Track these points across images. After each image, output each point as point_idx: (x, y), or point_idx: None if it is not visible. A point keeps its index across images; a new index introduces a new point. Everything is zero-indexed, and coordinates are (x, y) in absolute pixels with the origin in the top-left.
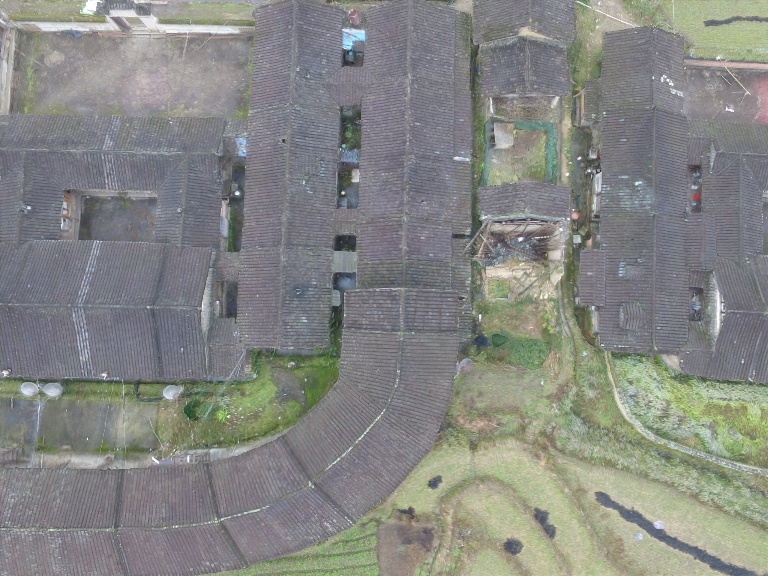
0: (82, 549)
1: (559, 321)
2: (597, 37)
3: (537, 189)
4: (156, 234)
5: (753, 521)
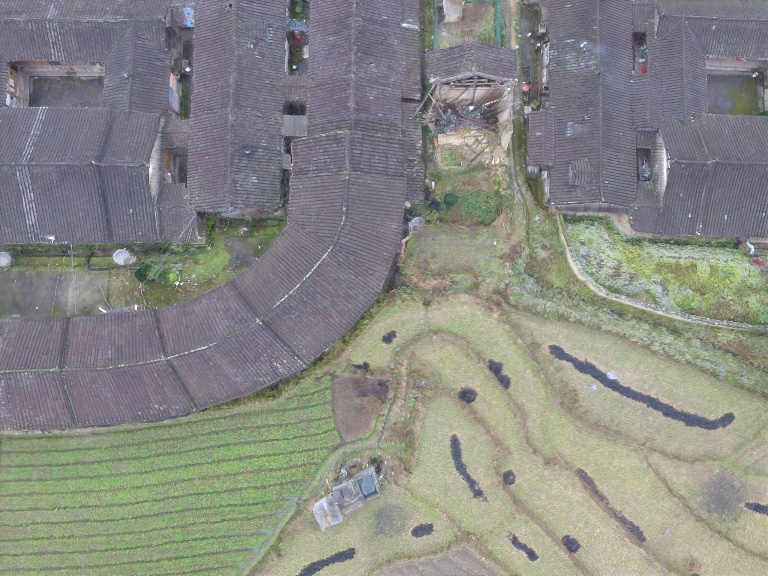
0: (26, 392)
1: (511, 186)
2: None
3: (484, 49)
4: (104, 103)
5: (703, 368)
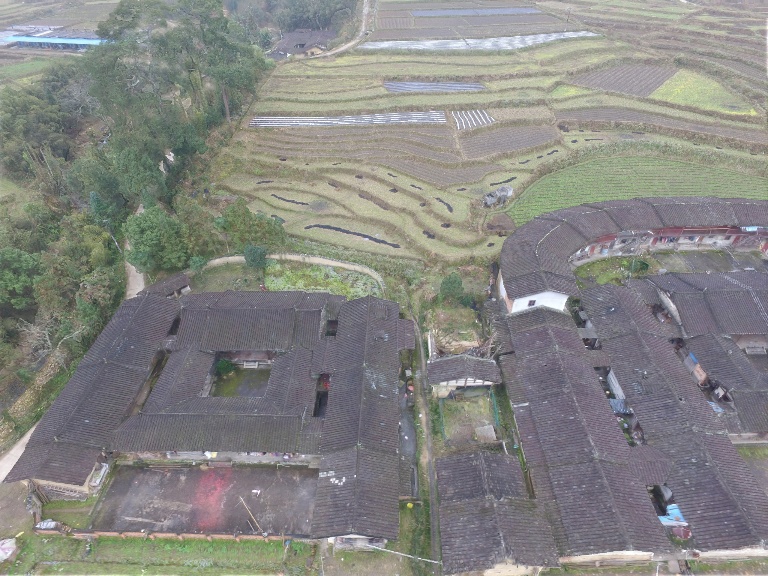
0: None
1: (422, 321)
2: (390, 572)
3: (459, 374)
4: None
5: (316, 242)
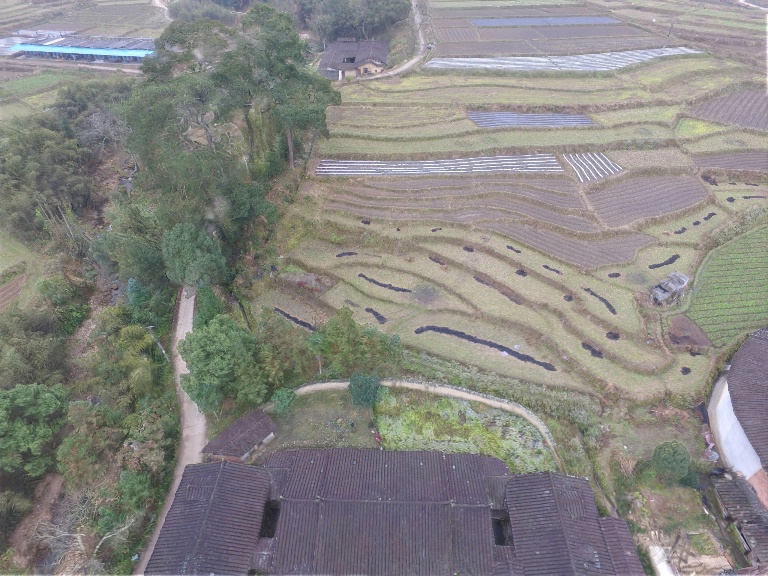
0: None
1: (626, 509)
2: None
3: None
4: None
5: (437, 357)
